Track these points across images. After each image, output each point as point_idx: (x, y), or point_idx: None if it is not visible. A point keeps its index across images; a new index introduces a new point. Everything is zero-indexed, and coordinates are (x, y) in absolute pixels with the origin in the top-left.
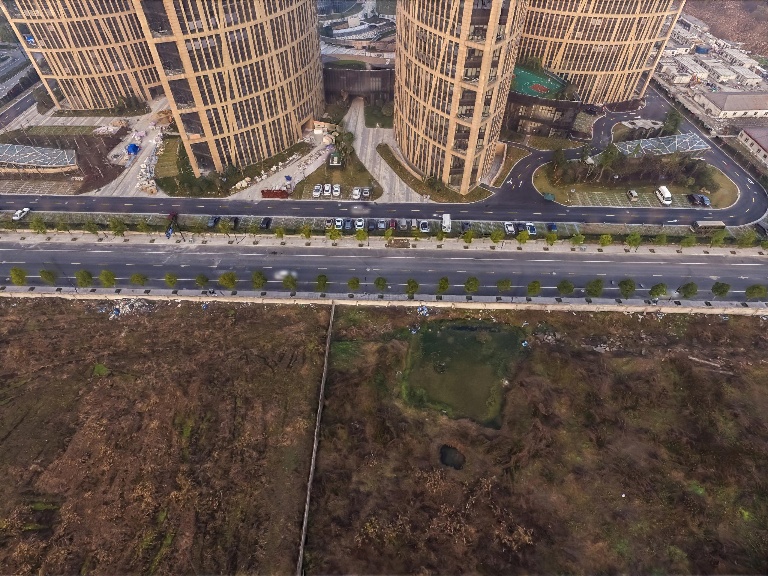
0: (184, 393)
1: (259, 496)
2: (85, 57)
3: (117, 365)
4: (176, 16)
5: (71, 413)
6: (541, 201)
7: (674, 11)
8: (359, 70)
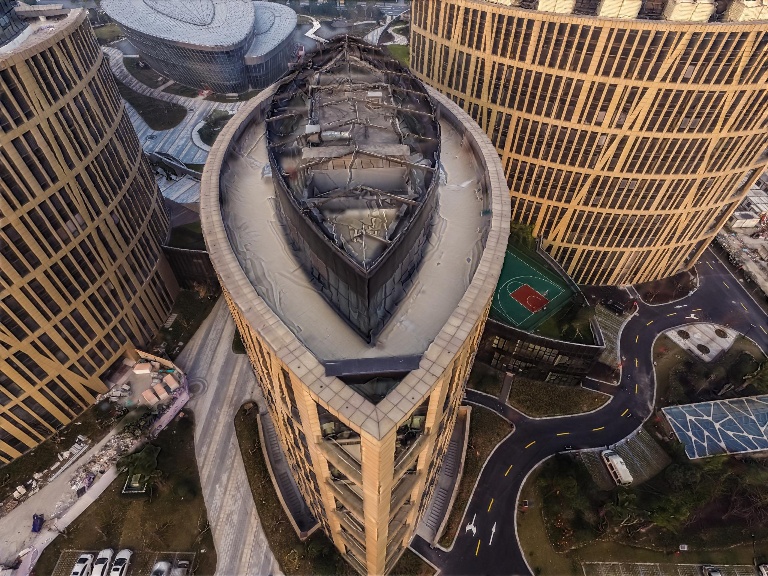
0: None
1: None
2: None
3: None
4: None
5: None
6: None
7: (761, 163)
8: None
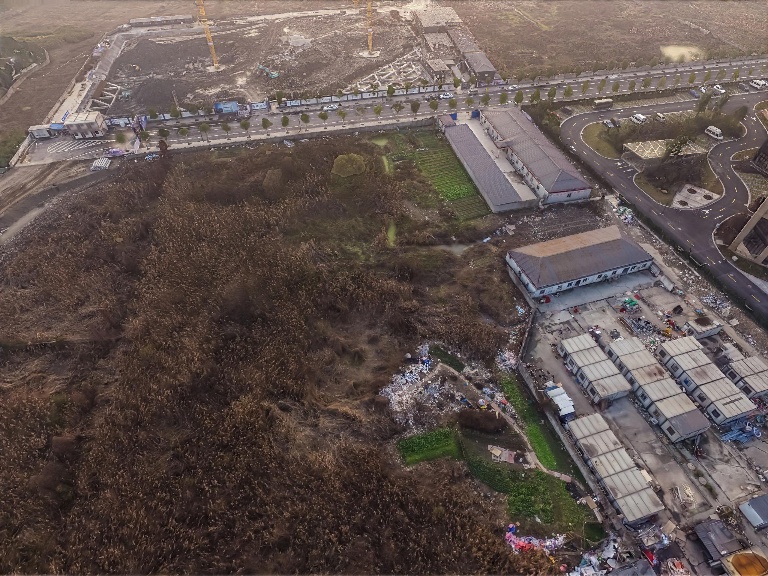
0: (767, 36)
1: None
2: None
3: None
4: None
5: None
6: None
7: None
8: None
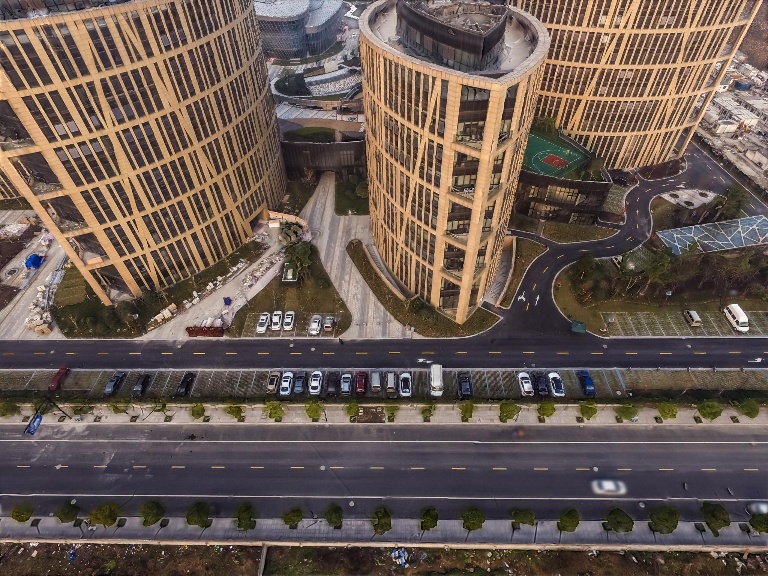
0: None
1: None
2: None
3: None
4: (33, 120)
5: None
6: (567, 330)
7: (725, 56)
8: (325, 143)
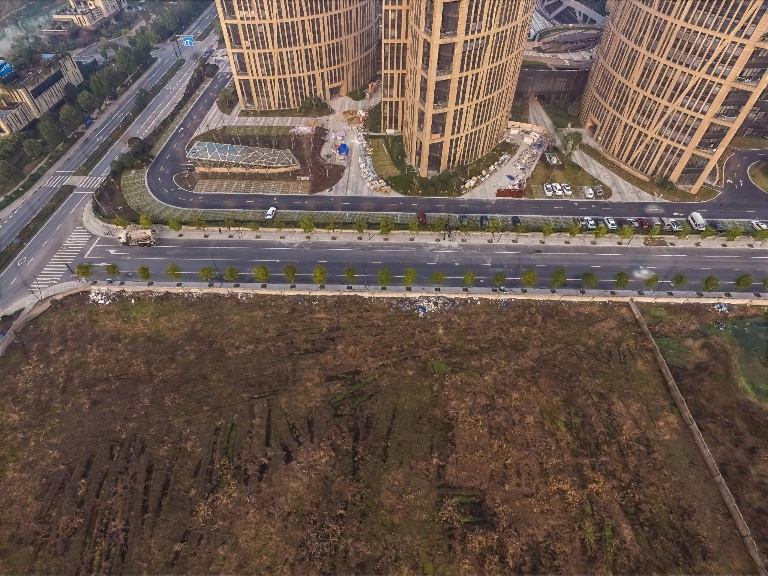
0: (538, 388)
1: (672, 488)
2: (284, 58)
3: (454, 361)
4: (466, 17)
5: (438, 408)
6: None
7: None
8: (549, 71)
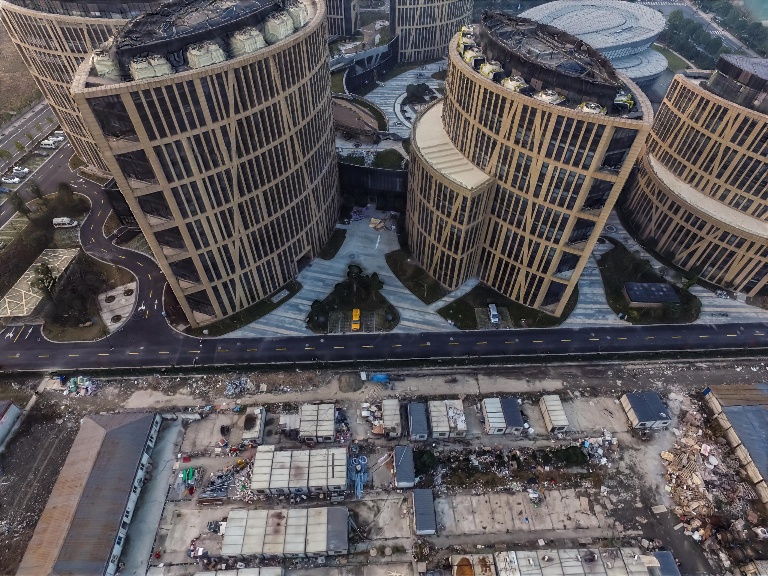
0: (6, 87)
1: None
2: None
3: None
4: None
5: None
6: (42, 192)
7: None
8: None
